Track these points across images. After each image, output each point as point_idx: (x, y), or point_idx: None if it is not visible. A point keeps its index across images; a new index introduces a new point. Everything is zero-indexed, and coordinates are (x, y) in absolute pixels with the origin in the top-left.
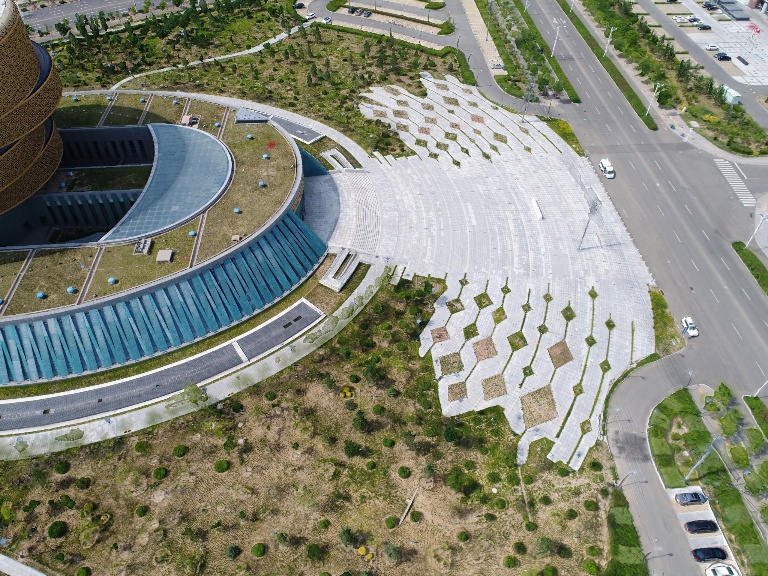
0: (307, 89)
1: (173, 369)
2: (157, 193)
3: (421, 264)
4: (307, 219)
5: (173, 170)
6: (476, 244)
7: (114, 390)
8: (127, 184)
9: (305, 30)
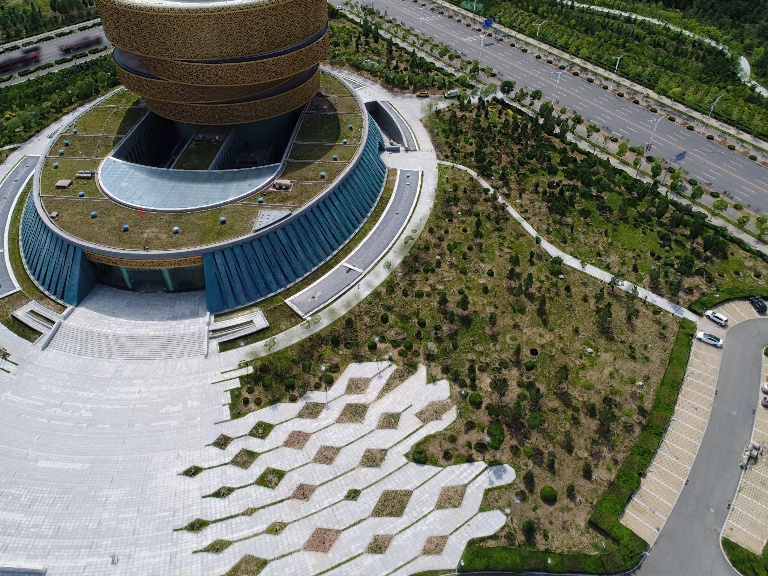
0: (433, 304)
1: (4, 224)
2: (156, 175)
3: (4, 388)
4: (132, 294)
5: (187, 180)
6: (0, 456)
7: (8, 202)
8: (184, 162)
9: (656, 310)
